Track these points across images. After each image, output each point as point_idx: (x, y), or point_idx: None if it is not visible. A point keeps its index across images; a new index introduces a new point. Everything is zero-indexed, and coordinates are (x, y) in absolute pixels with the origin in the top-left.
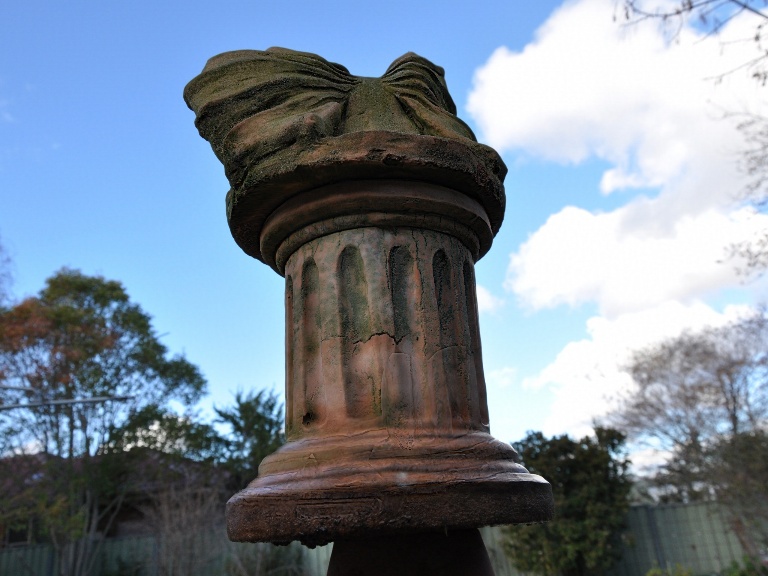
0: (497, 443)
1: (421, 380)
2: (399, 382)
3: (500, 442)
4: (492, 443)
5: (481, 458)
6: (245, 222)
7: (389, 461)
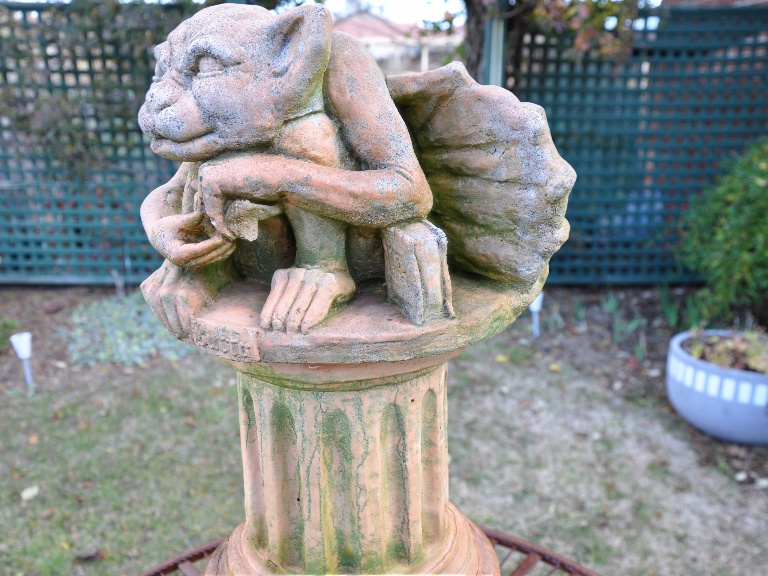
0: None
1: None
2: None
3: None
4: None
5: None
6: None
7: (238, 568)
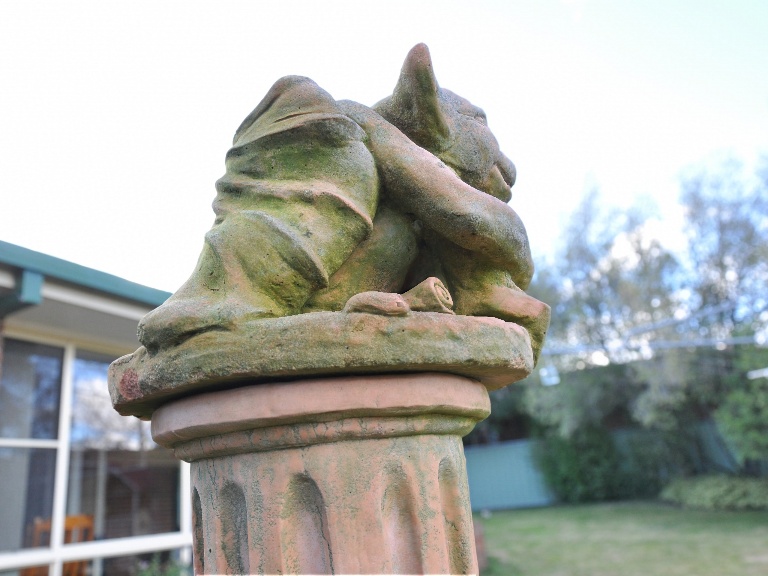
0: None
1: None
2: None
3: None
4: None
5: None
6: None
7: None
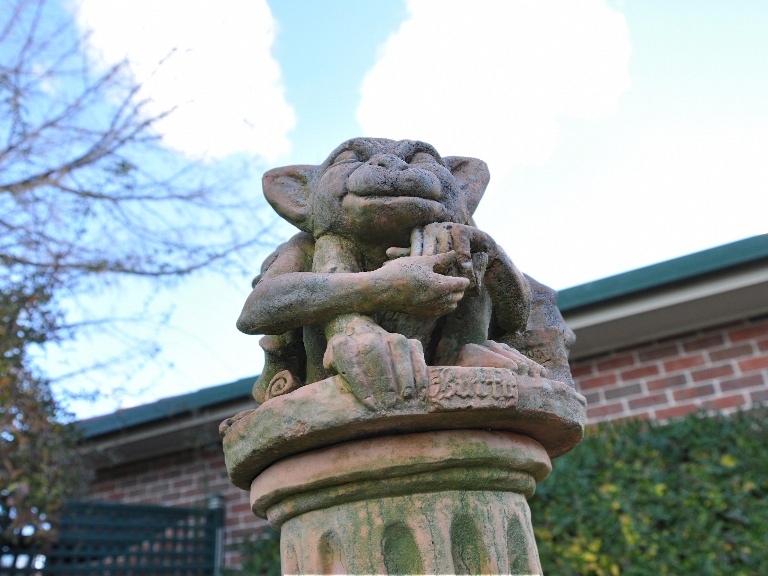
0: None
1: None
2: None
3: None
4: None
5: None
6: (553, 454)
7: None
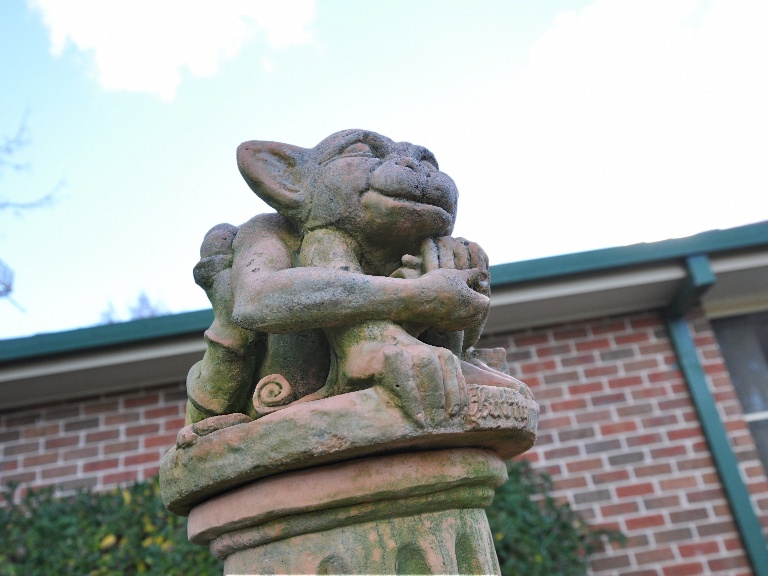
0: None
1: None
2: None
3: None
4: None
5: None
6: None
7: None
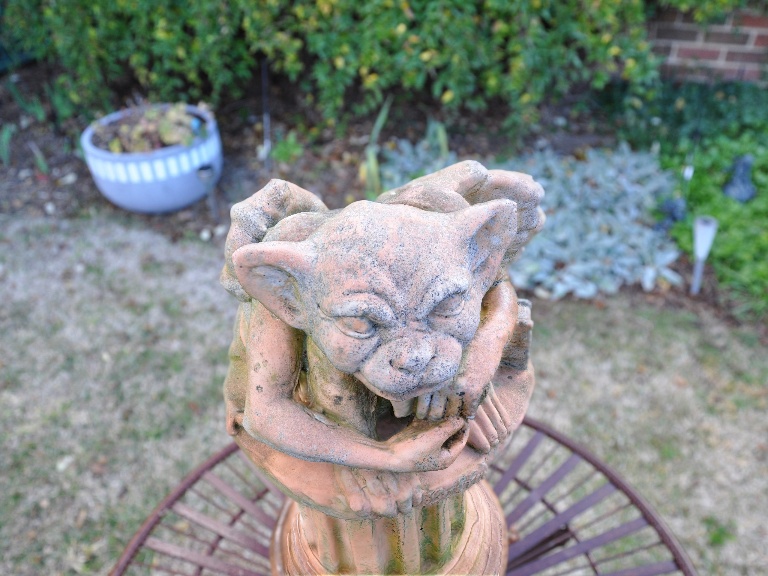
0: (296, 530)
1: (343, 535)
2: (366, 551)
3: (296, 522)
4: (299, 534)
5: (303, 573)
6: None
7: None
